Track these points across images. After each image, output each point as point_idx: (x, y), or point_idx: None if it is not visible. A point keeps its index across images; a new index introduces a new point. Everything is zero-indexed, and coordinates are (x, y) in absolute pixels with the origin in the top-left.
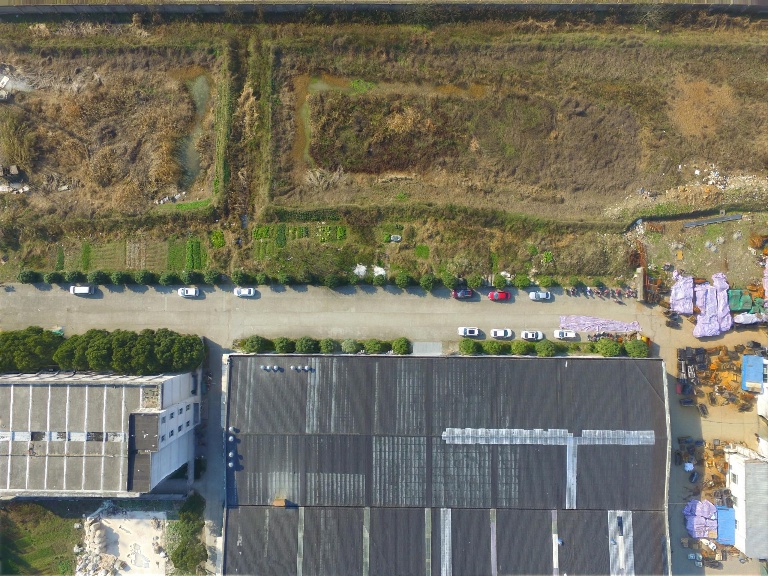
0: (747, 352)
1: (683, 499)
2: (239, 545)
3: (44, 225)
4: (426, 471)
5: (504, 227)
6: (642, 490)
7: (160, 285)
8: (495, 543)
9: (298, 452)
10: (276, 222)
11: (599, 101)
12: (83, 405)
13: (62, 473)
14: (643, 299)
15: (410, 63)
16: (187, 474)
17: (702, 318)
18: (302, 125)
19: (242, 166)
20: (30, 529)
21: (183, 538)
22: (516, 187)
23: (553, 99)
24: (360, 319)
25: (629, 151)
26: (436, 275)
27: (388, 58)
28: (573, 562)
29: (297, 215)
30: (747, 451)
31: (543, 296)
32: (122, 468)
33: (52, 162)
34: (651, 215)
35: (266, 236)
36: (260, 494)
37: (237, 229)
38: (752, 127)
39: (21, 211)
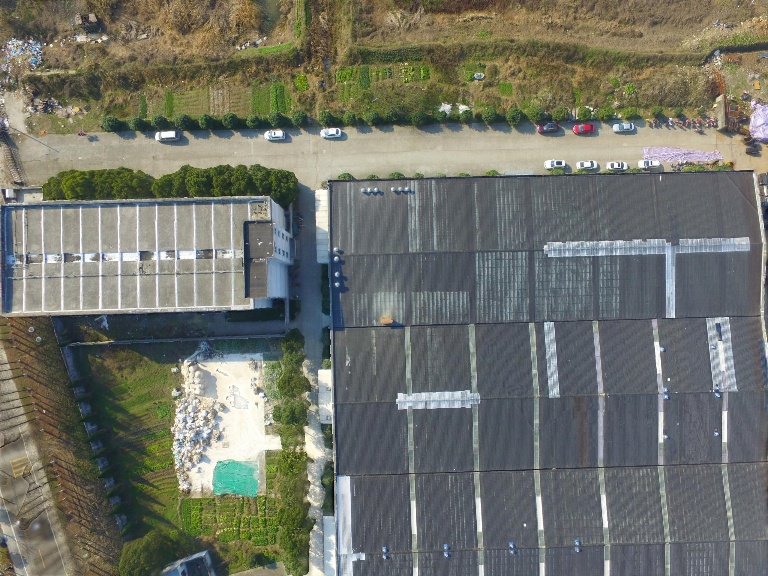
0: None
1: None
2: (348, 365)
3: (126, 73)
4: (529, 285)
5: (585, 63)
6: (739, 296)
7: (246, 130)
8: (599, 353)
9: (402, 271)
10: (359, 64)
11: None
12: (191, 223)
13: (173, 291)
14: (725, 125)
15: None
16: None
17: None
18: None
19: (322, 10)
20: (126, 376)
21: (287, 367)
22: (595, 23)
23: None
24: (447, 157)
25: None
26: None
27: None
28: (675, 367)
29: (381, 55)
30: None
31: (627, 127)
32: (233, 284)
33: (130, 11)
34: (728, 45)
35: (350, 78)
36: (366, 315)
37: (320, 72)
38: None
39: (101, 60)
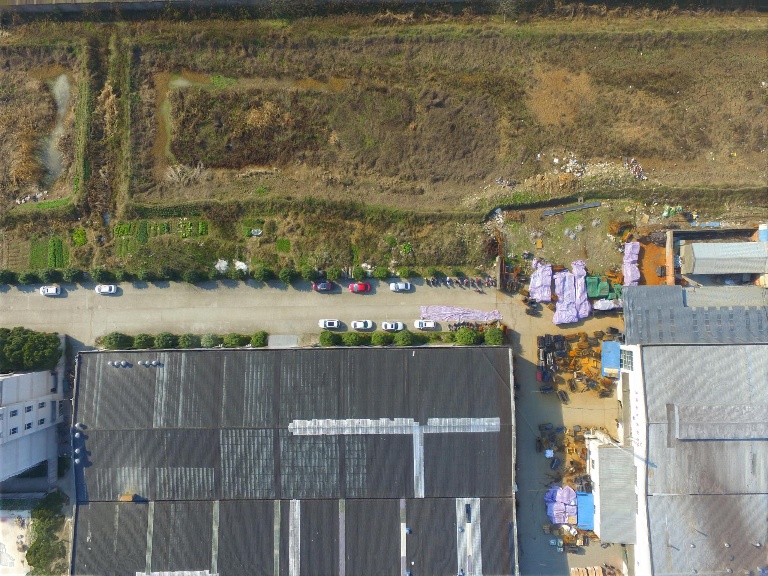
0: (606, 338)
1: (545, 486)
2: (88, 541)
3: None
4: (274, 463)
5: (364, 219)
6: (489, 477)
7: (22, 284)
8: (343, 533)
9: (146, 447)
10: (138, 219)
11: (458, 92)
12: None
13: None
14: (500, 288)
15: (269, 58)
16: (49, 472)
17: (560, 305)
18: (163, 122)
19: (104, 164)
20: None
21: (38, 536)
22: (376, 179)
23: (412, 91)
24: (222, 314)
25: (487, 141)
26: (297, 268)
27: (247, 53)
28: (421, 550)
29: (157, 211)
30: (602, 436)
31: (402, 287)
32: None
33: None
34: (509, 204)
35: (128, 233)
36: (110, 490)
37: (99, 227)
38: (610, 115)
39: None
